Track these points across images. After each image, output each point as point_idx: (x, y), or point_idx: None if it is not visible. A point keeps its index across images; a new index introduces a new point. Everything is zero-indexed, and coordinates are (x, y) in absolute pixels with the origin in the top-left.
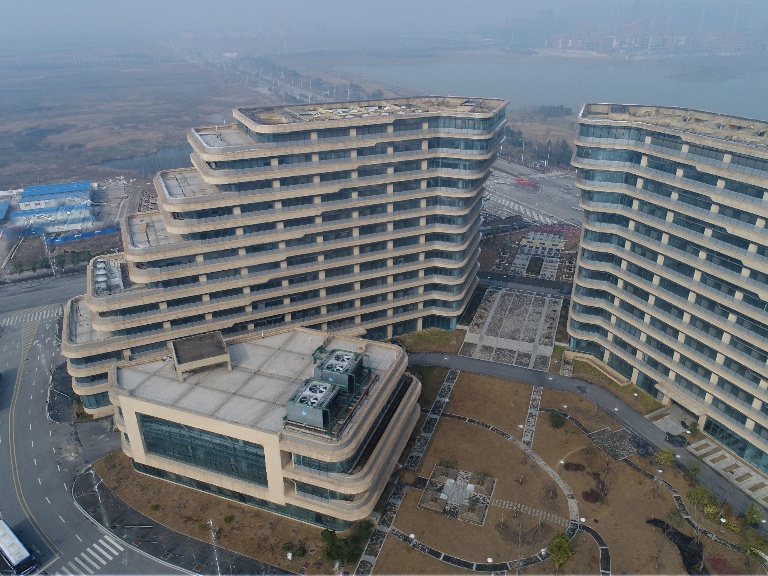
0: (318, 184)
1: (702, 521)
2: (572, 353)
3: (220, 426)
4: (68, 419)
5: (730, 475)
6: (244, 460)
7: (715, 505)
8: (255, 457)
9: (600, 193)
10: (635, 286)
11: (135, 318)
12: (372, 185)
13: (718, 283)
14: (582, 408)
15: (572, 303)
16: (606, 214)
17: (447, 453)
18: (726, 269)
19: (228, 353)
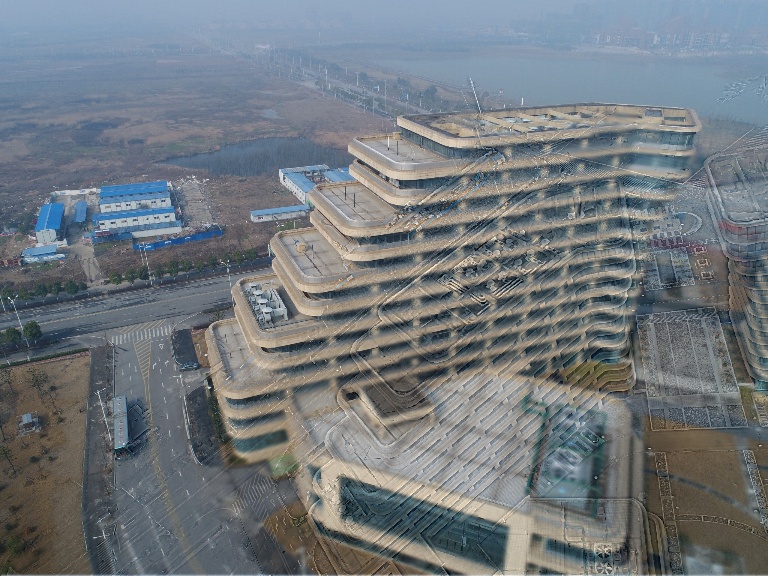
0: (492, 367)
1: None
2: (760, 393)
3: None
4: None
5: None
6: None
7: None
8: None
9: (765, 275)
10: None
11: (388, 537)
12: None
13: None
14: None
15: (745, 346)
16: None
17: (706, 569)
18: None
19: (499, 570)
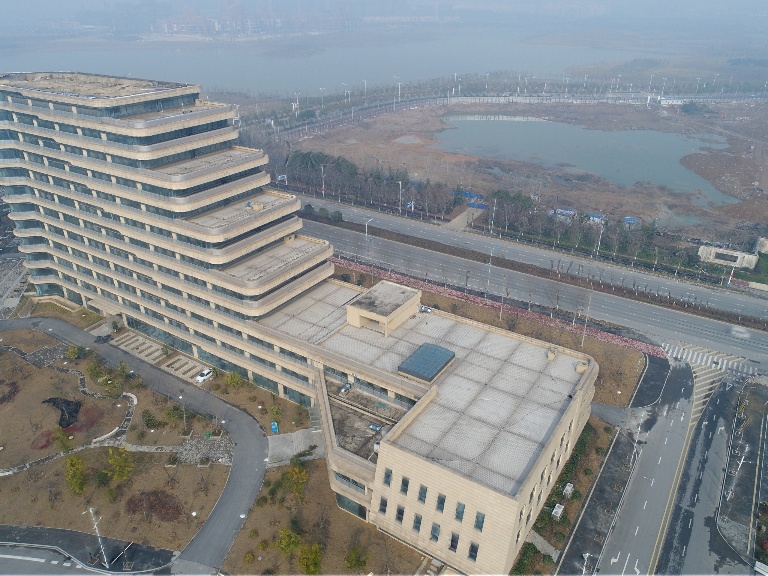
0: None
1: (93, 388)
2: (39, 298)
3: None
4: None
5: (135, 351)
6: None
7: (109, 374)
8: None
9: None
10: (53, 226)
11: None
12: None
13: (87, 207)
14: (27, 338)
15: None
16: (9, 169)
17: None
18: (85, 194)
19: None
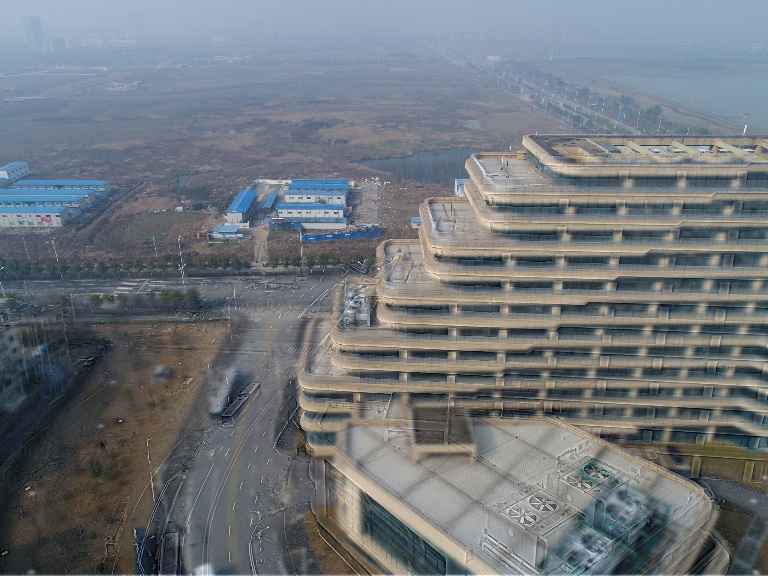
0: (619, 239)
1: None
2: None
3: (401, 510)
4: (290, 453)
5: None
6: (422, 570)
7: None
8: (435, 571)
9: None
10: None
11: (372, 360)
12: (700, 251)
13: None
14: None
15: None
16: None
17: None
18: None
19: (447, 421)
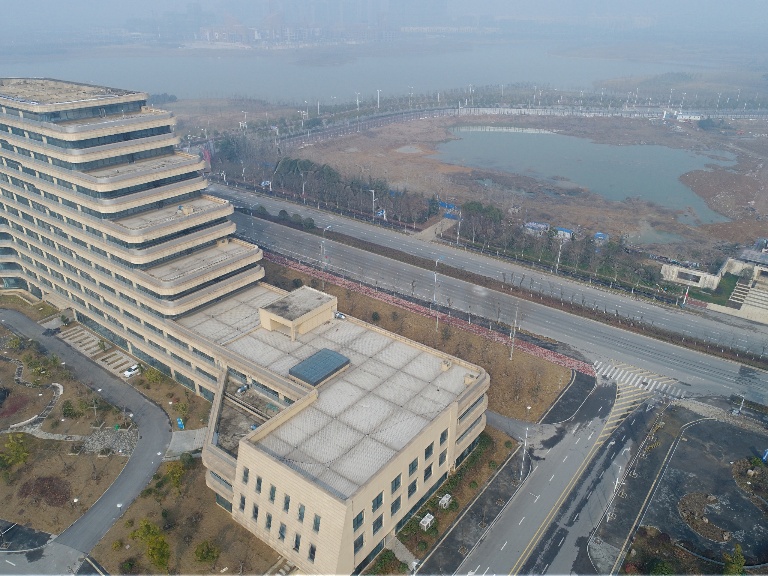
0: None
1: (27, 377)
2: None
3: None
4: None
5: (77, 344)
6: None
7: (46, 365)
8: None
9: None
10: (15, 223)
11: None
12: None
13: (38, 206)
14: None
15: None
16: None
17: None
18: (35, 194)
19: None
